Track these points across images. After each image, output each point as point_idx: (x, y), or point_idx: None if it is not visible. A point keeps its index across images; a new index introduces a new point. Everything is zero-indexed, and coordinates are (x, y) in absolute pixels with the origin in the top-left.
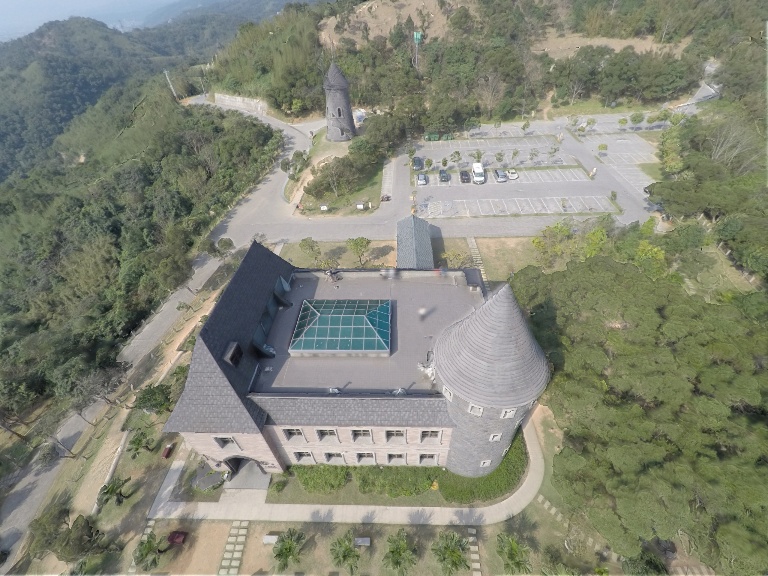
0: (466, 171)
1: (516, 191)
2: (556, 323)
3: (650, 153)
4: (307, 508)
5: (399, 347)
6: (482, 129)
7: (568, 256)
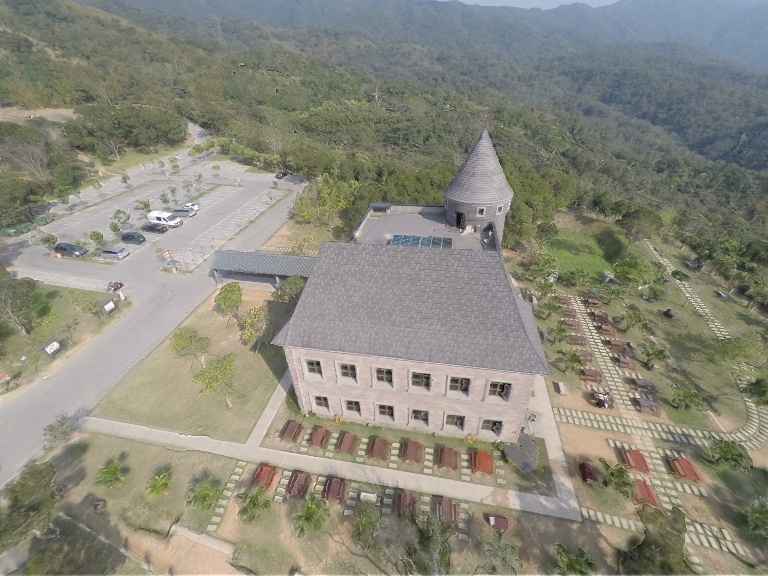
0: (147, 225)
1: (217, 213)
2: None
3: (237, 165)
4: None
5: None
6: None
7: (321, 216)
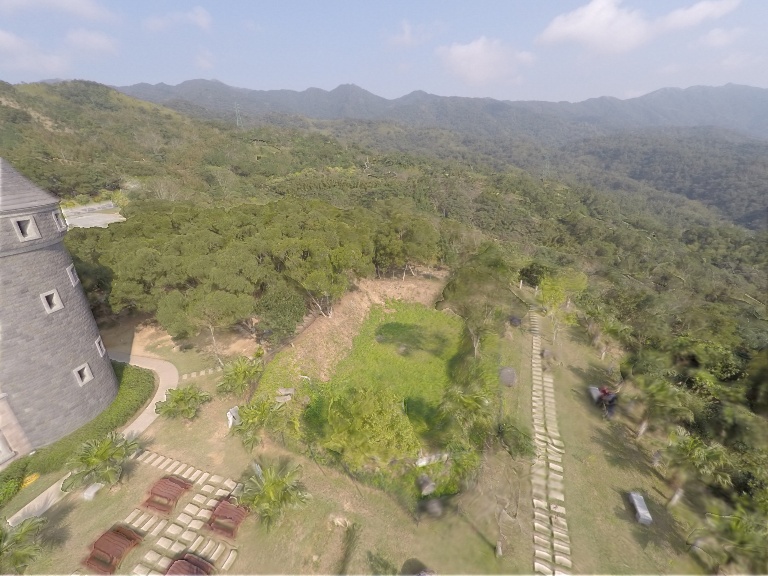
0: None
1: None
2: (82, 261)
3: (114, 217)
4: None
5: None
6: None
7: None
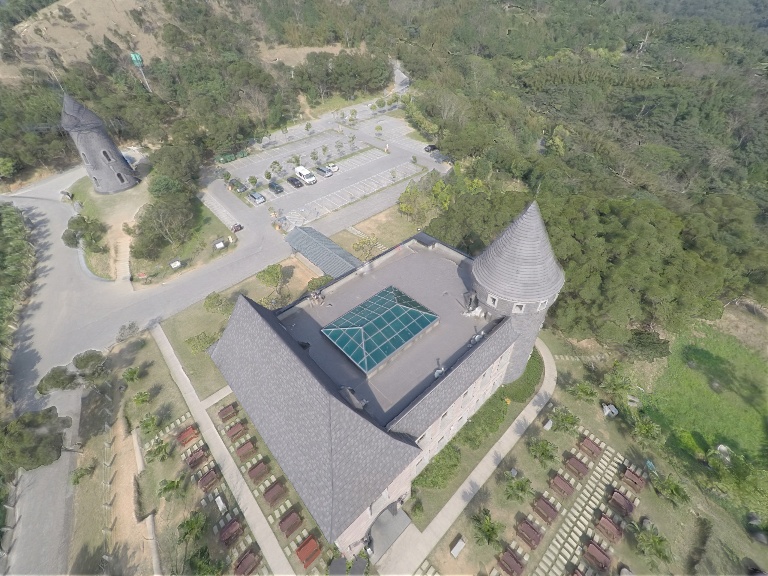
0: (292, 177)
1: (347, 179)
2: (485, 246)
3: (405, 126)
4: (455, 499)
5: (437, 313)
6: (268, 139)
7: None
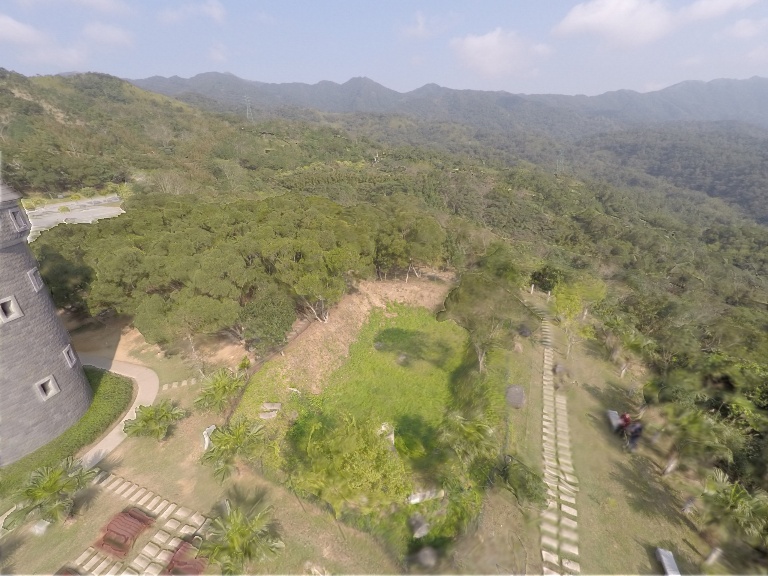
0: None
1: None
2: (65, 260)
3: (119, 211)
4: None
5: None
6: None
7: None
